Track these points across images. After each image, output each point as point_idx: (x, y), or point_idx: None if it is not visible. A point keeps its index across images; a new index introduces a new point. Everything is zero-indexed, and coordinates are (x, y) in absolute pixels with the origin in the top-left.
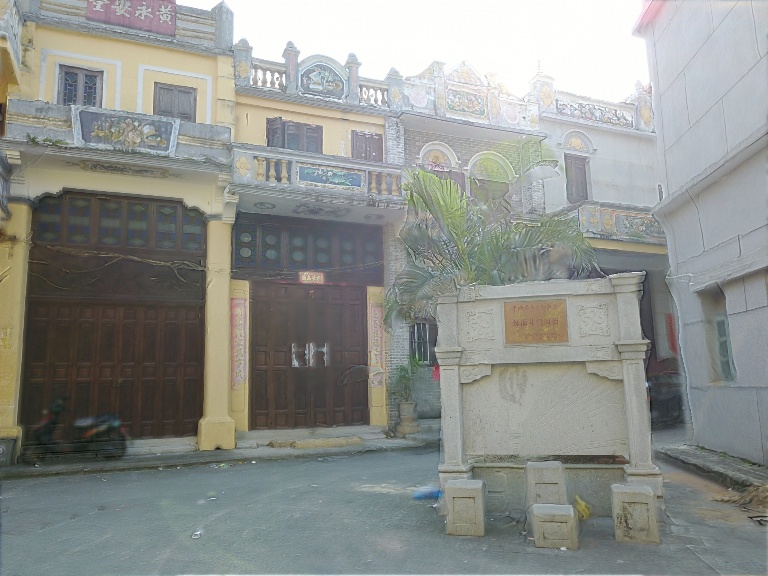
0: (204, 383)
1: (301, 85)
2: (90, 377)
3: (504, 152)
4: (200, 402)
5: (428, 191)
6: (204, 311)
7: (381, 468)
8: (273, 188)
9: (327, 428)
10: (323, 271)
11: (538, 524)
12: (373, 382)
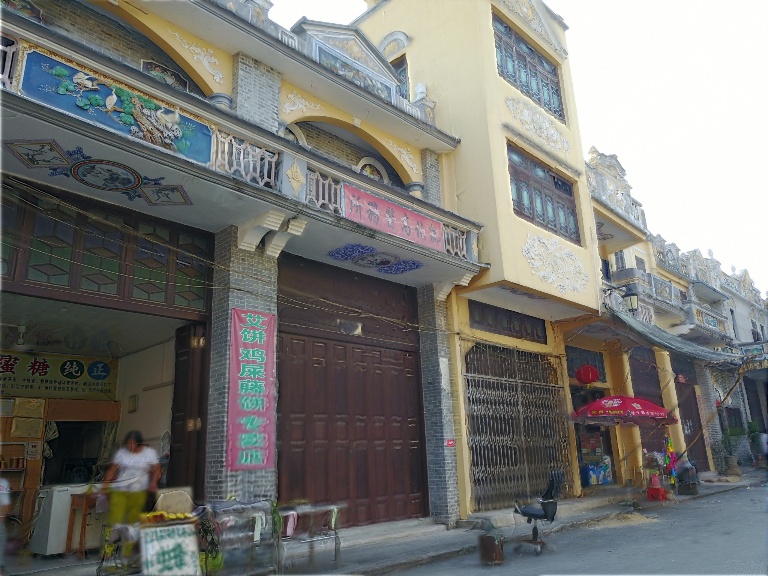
0: (677, 443)
1: None
2: (643, 439)
3: None
4: None
5: None
6: (662, 398)
7: None
8: None
9: None
10: None
11: None
12: (707, 444)
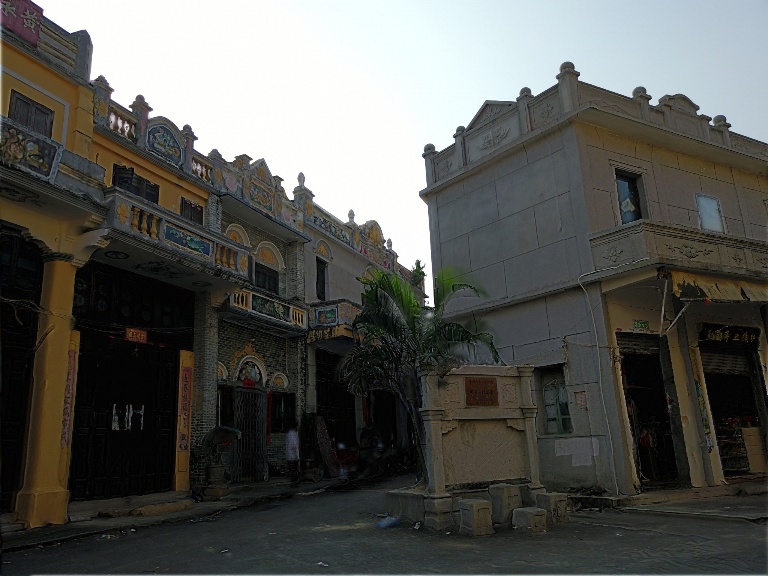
0: (34, 446)
1: (148, 141)
2: None
3: (277, 245)
4: (20, 470)
5: (401, 290)
6: (33, 361)
7: (280, 519)
8: (148, 242)
9: (140, 496)
10: (147, 330)
11: (533, 518)
12: (181, 446)
